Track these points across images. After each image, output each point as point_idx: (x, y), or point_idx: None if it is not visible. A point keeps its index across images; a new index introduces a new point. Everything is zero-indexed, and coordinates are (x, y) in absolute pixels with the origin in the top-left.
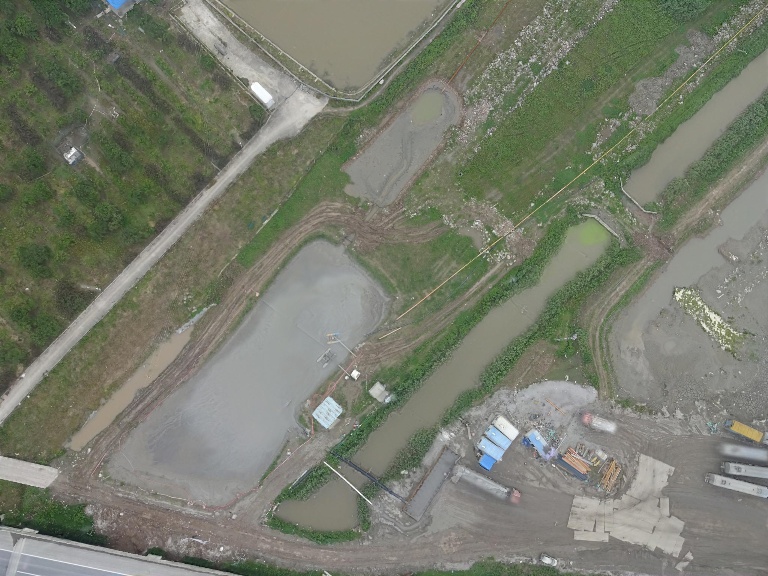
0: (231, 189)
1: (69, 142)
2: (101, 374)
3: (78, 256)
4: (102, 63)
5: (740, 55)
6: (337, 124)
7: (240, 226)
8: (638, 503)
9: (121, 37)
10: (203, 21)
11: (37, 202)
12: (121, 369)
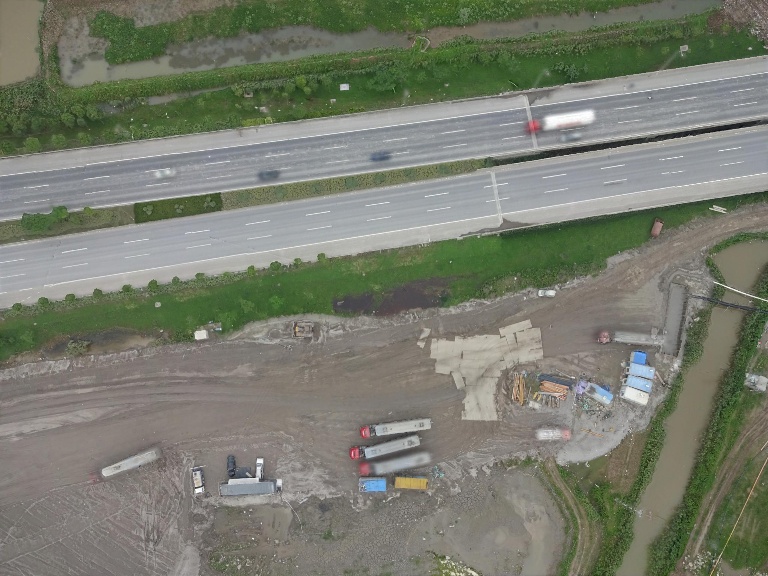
0: None
1: None
2: None
3: None
4: None
5: None
6: None
7: None
8: (484, 374)
9: None
10: None
11: None
12: None
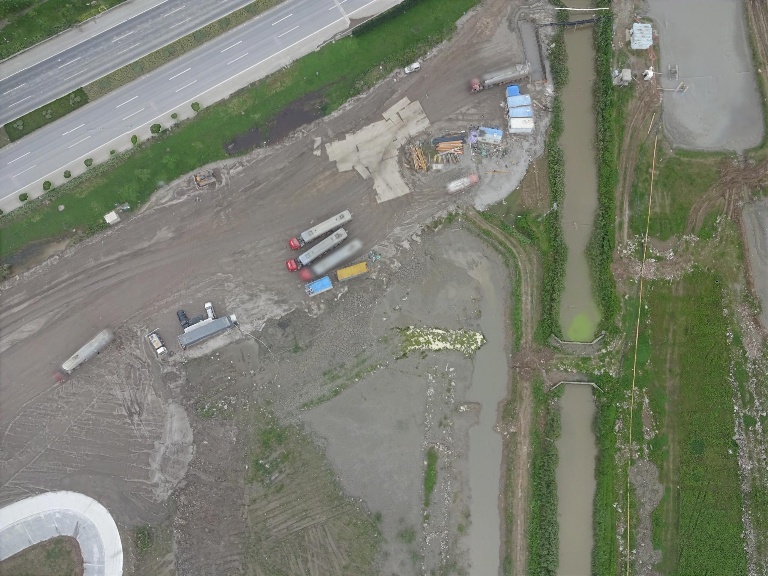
0: None
1: None
2: None
3: None
4: None
5: None
6: None
7: None
8: (383, 157)
9: None
10: None
11: None
12: None
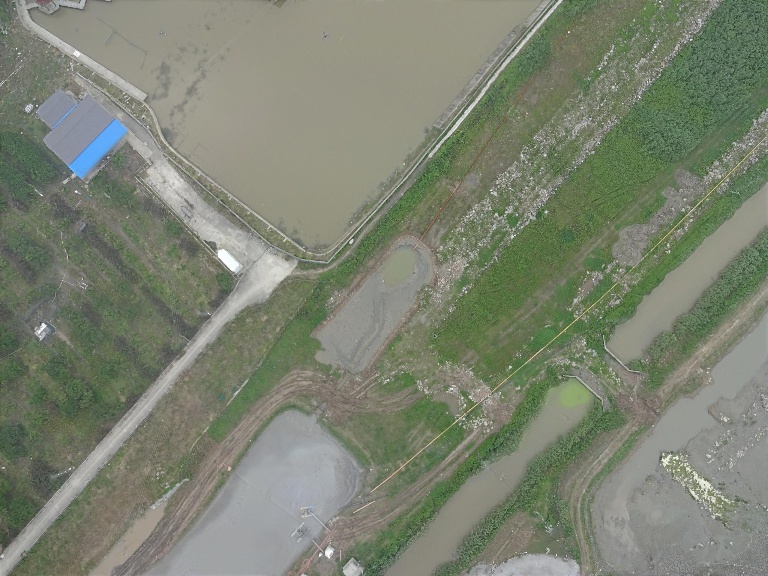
0: (201, 359)
1: (39, 315)
2: (78, 552)
3: (51, 434)
4: (69, 232)
5: (733, 197)
6: (307, 287)
7: (211, 398)
8: None
9: (87, 203)
10: (169, 182)
11: (9, 380)
12: (97, 547)
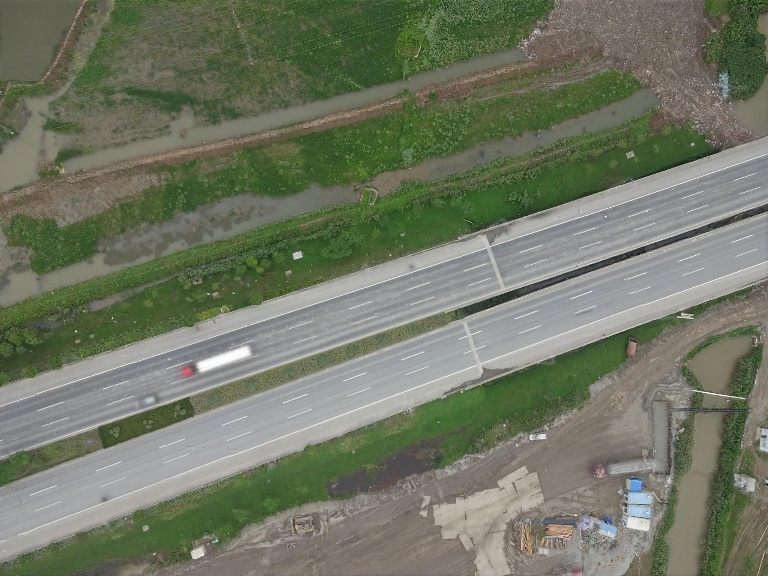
0: None
1: None
2: None
3: None
4: None
5: None
6: None
7: None
8: (490, 530)
9: None
10: None
11: None
12: None
